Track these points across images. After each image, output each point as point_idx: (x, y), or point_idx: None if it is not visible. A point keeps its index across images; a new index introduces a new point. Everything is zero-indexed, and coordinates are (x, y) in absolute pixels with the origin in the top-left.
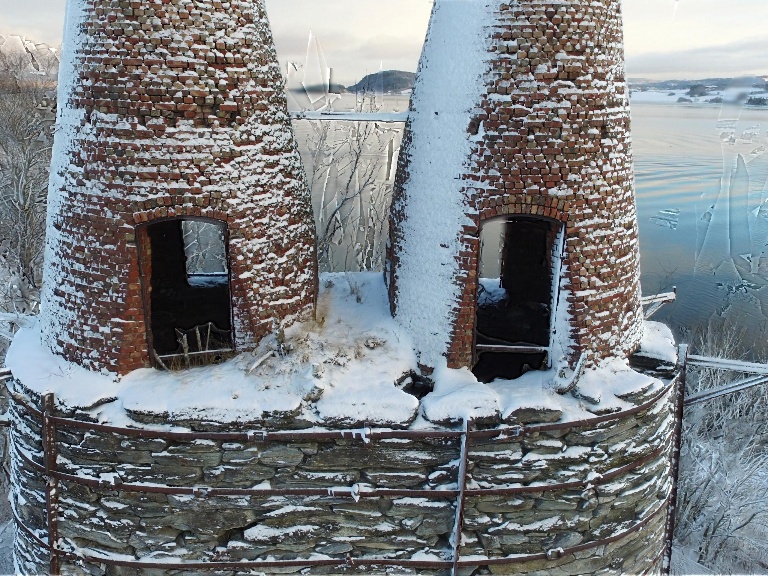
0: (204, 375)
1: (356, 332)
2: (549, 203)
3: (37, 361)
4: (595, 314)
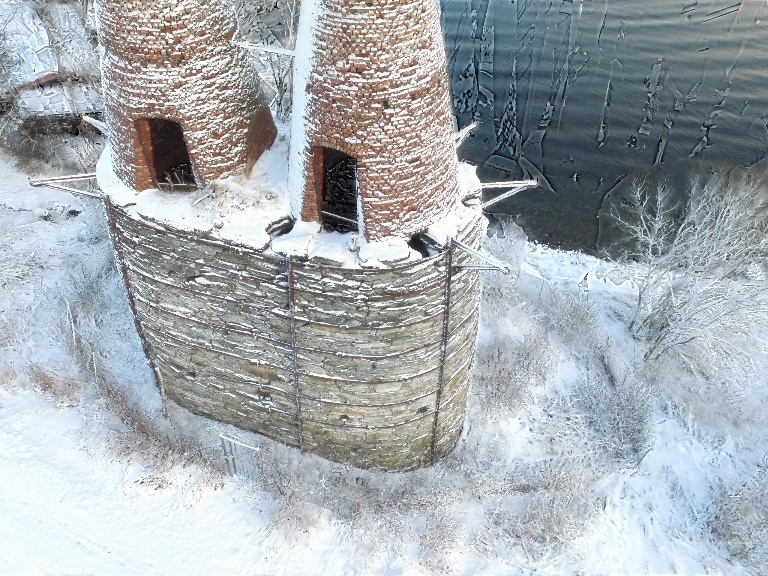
0: (175, 201)
1: (267, 186)
2: (346, 146)
3: (107, 173)
4: (378, 212)
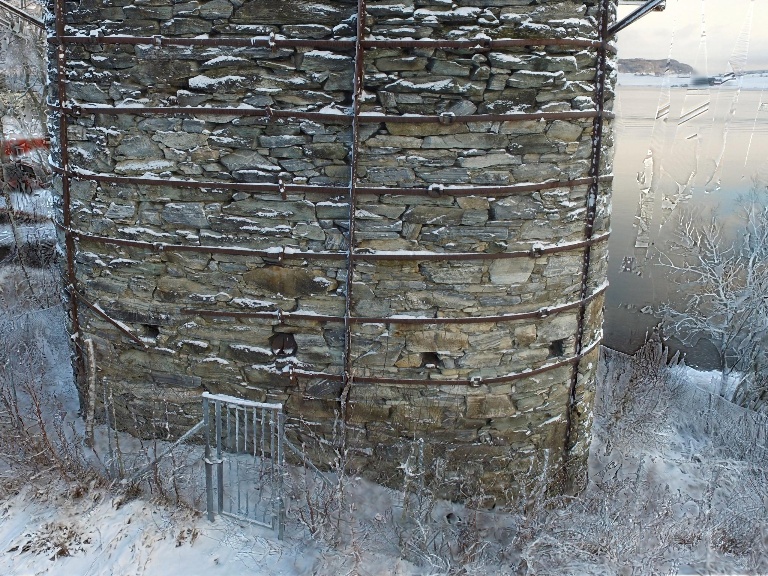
0: None
1: None
2: None
3: None
4: None
